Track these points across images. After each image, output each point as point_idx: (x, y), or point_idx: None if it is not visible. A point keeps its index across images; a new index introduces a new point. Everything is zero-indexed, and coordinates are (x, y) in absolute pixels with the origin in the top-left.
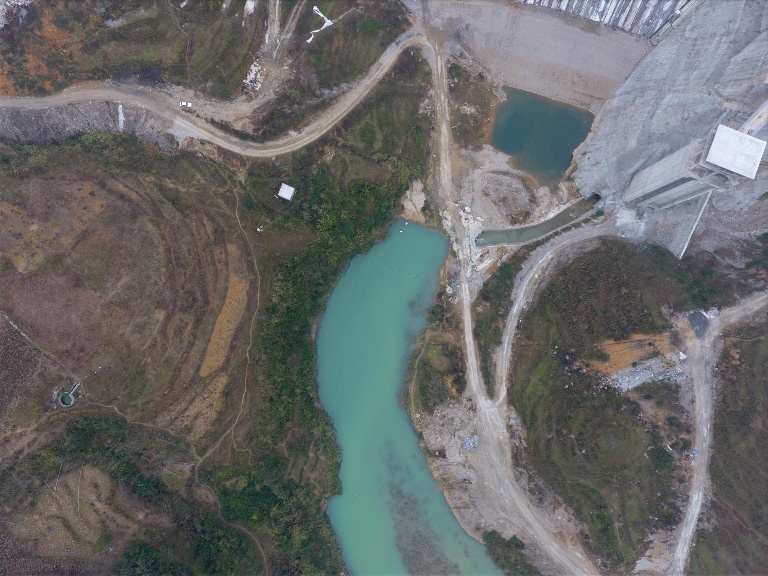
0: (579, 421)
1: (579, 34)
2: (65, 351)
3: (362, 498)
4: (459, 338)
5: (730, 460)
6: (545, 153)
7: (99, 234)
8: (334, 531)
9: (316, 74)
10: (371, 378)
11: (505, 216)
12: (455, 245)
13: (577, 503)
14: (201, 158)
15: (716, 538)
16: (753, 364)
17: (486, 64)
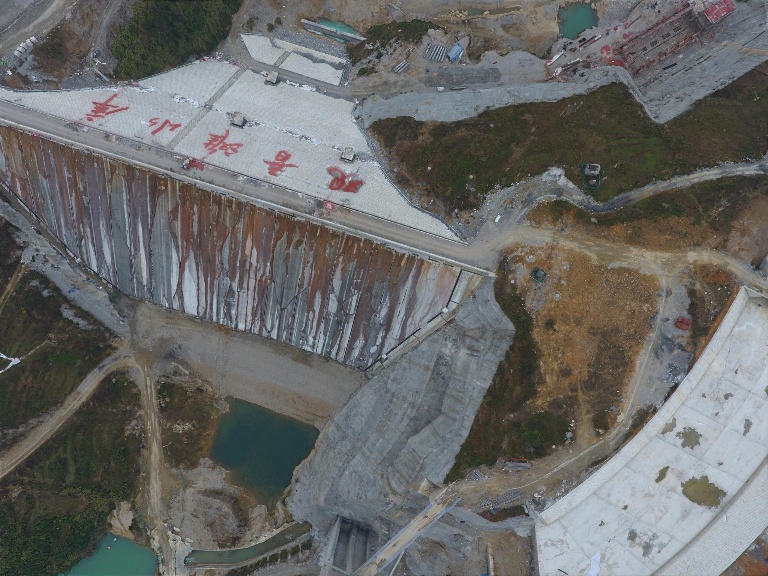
0: None
1: (291, 363)
2: None
3: None
4: None
5: None
6: (267, 467)
7: None
8: None
9: None
10: None
11: None
12: (161, 567)
13: None
14: None
15: None
16: None
17: (206, 377)
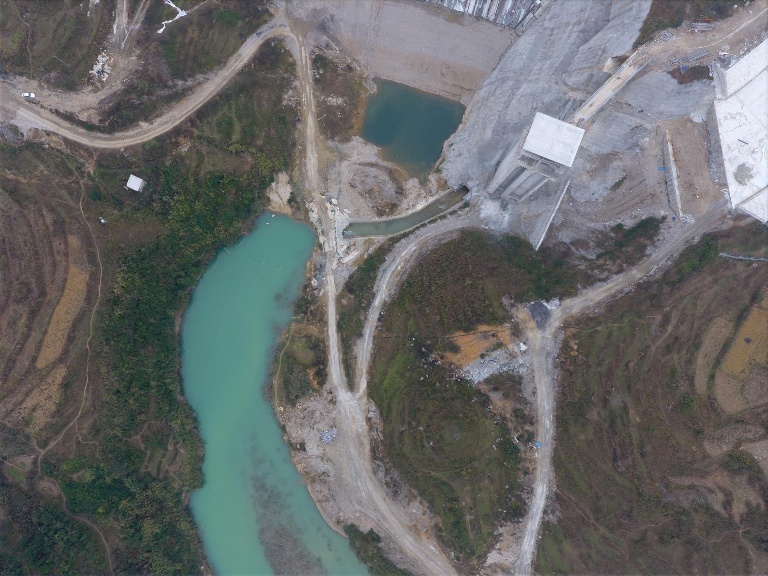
0: (427, 413)
1: (443, 24)
2: None
3: (226, 491)
4: (322, 330)
5: (571, 452)
6: (416, 145)
7: None
8: (196, 525)
9: (168, 65)
10: (237, 371)
11: (371, 208)
12: (321, 237)
13: (431, 496)
14: (48, 149)
15: (561, 531)
16: (589, 355)
17: (355, 55)
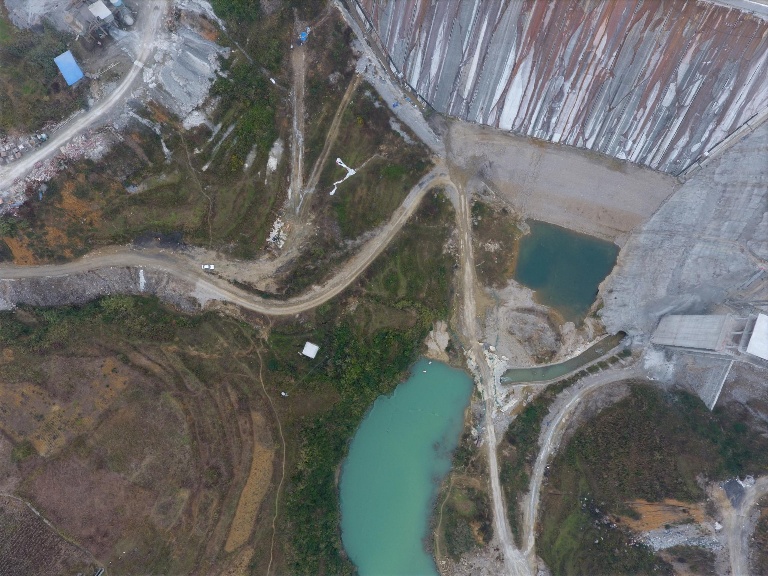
0: None
1: (605, 172)
2: (89, 537)
3: None
4: (485, 483)
5: None
6: (570, 286)
7: (122, 412)
8: None
9: (339, 226)
10: (395, 521)
11: (531, 356)
12: (480, 386)
13: None
14: (223, 318)
15: None
16: None
17: (510, 198)
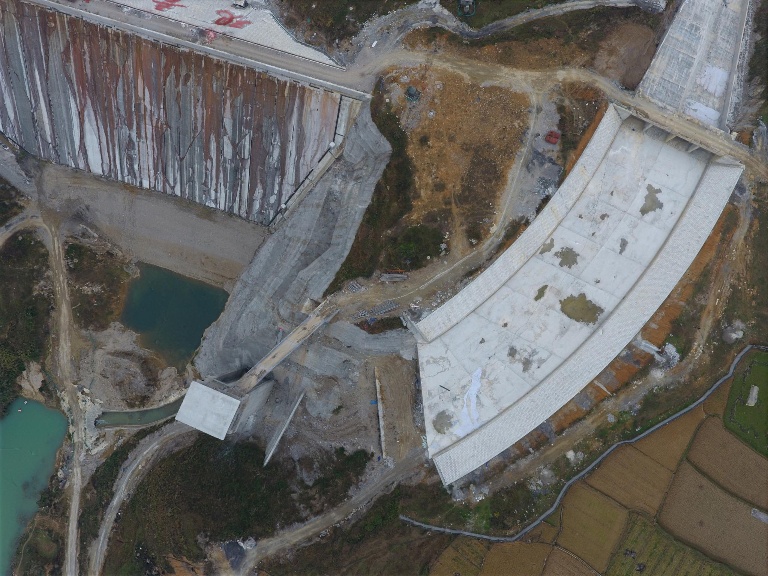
0: None
1: (195, 220)
2: None
3: None
4: (63, 526)
5: None
6: (178, 331)
7: None
8: None
9: None
10: None
11: (121, 400)
12: (70, 427)
13: None
14: None
15: None
16: None
17: (116, 241)
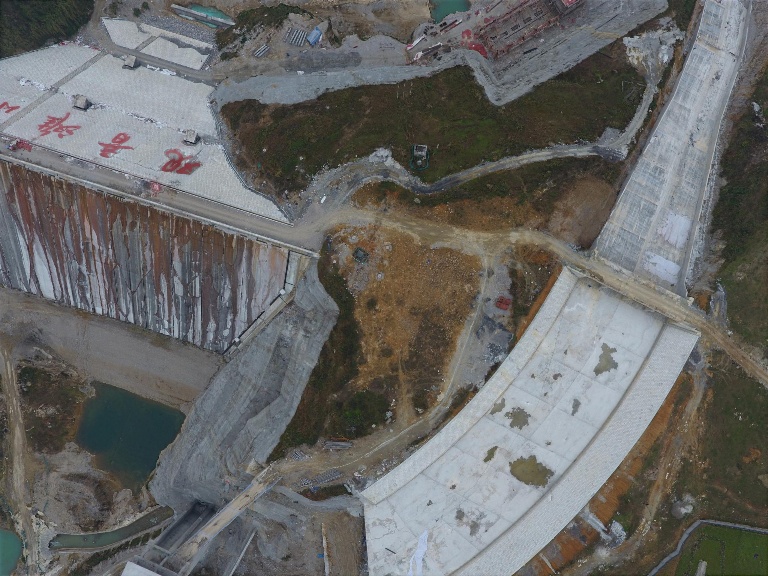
0: None
1: (149, 347)
2: None
3: None
4: None
5: None
6: (133, 452)
7: None
8: None
9: None
10: None
11: (75, 524)
12: (24, 551)
13: None
14: None
15: None
16: None
17: (71, 362)
